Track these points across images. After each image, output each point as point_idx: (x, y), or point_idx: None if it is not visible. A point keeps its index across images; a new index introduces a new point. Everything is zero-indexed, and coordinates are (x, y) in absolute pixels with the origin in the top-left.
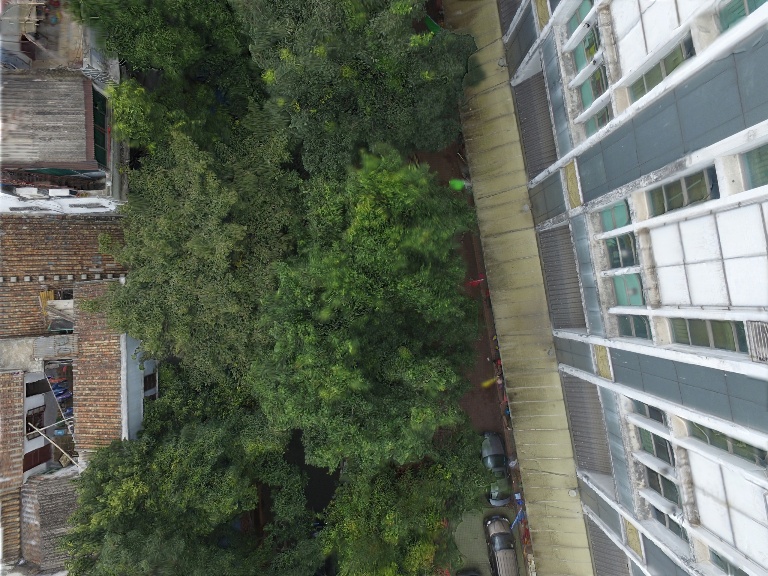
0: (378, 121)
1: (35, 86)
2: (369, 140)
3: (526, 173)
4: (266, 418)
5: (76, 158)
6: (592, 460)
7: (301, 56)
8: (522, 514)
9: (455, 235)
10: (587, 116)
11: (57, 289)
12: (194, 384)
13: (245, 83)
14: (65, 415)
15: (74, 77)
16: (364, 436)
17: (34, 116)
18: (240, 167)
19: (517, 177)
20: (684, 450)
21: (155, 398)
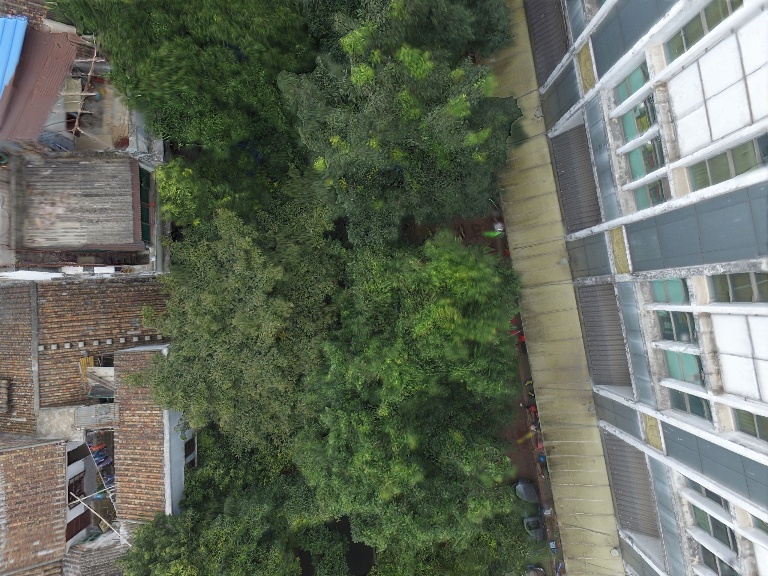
0: (424, 193)
1: (82, 168)
2: (415, 213)
3: (564, 225)
4: (309, 489)
5: (123, 240)
6: (635, 520)
7: (357, 148)
8: (557, 563)
9: None
10: (638, 186)
11: (97, 355)
12: (235, 451)
13: (286, 150)
14: (106, 484)
15: (121, 158)
16: (418, 525)
17: (82, 198)
18: (283, 238)
19: (554, 228)
20: (749, 541)
21: (194, 462)
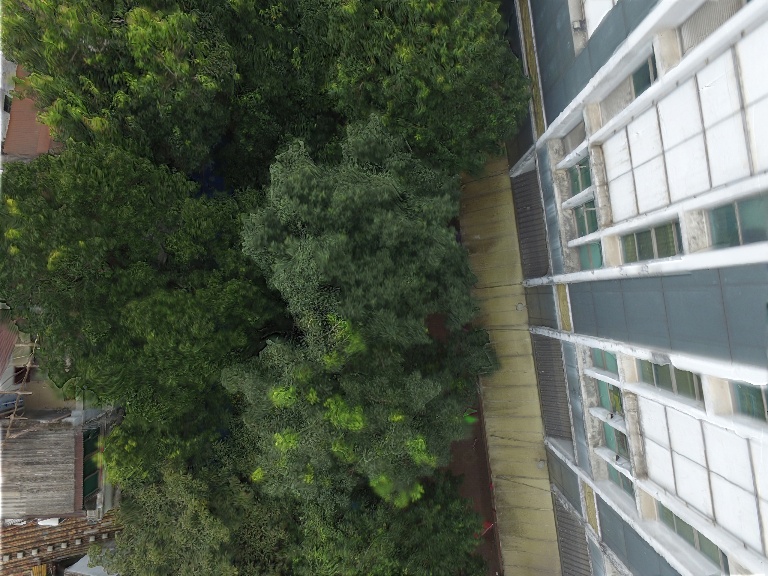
0: None
1: (25, 436)
2: (370, 476)
3: (542, 423)
4: None
5: (64, 510)
6: None
7: (294, 482)
8: None
9: (466, 442)
10: None
11: (49, 565)
12: None
13: None
14: None
15: None
16: None
17: (23, 467)
18: (236, 481)
19: (533, 423)
20: None
21: None
